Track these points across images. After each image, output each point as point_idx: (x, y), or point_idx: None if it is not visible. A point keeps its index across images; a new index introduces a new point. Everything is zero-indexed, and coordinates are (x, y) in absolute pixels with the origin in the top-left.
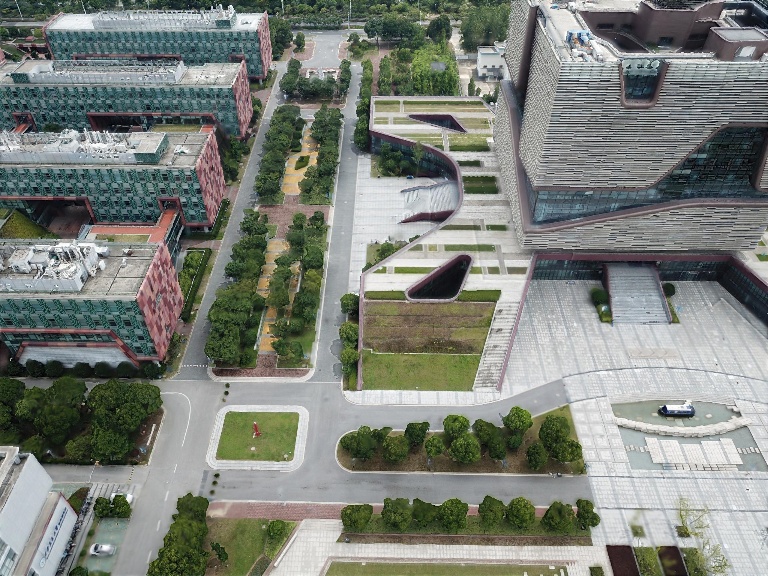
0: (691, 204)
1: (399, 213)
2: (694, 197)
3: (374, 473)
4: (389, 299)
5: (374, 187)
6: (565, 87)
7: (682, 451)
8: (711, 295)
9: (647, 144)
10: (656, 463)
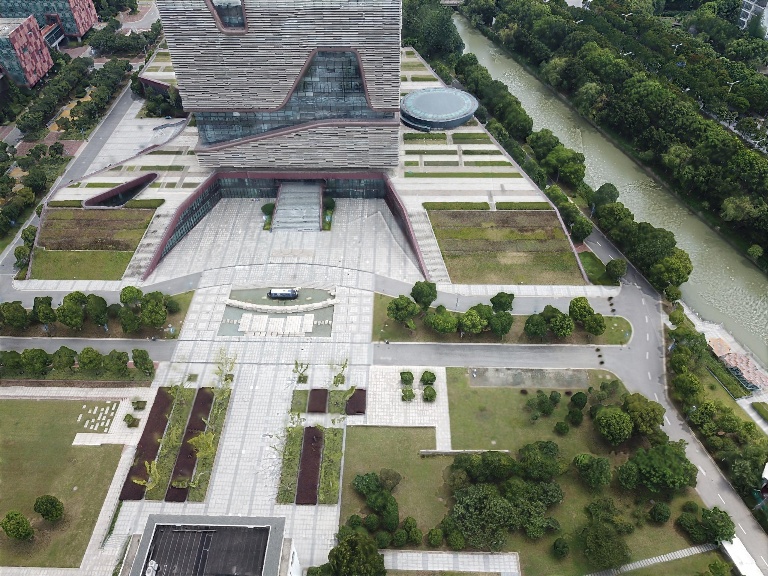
0: (323, 124)
1: (142, 146)
2: (328, 118)
3: (4, 338)
4: (67, 206)
5: (133, 126)
6: (168, 16)
7: (267, 323)
8: (371, 209)
9: (260, 68)
10: (239, 331)
